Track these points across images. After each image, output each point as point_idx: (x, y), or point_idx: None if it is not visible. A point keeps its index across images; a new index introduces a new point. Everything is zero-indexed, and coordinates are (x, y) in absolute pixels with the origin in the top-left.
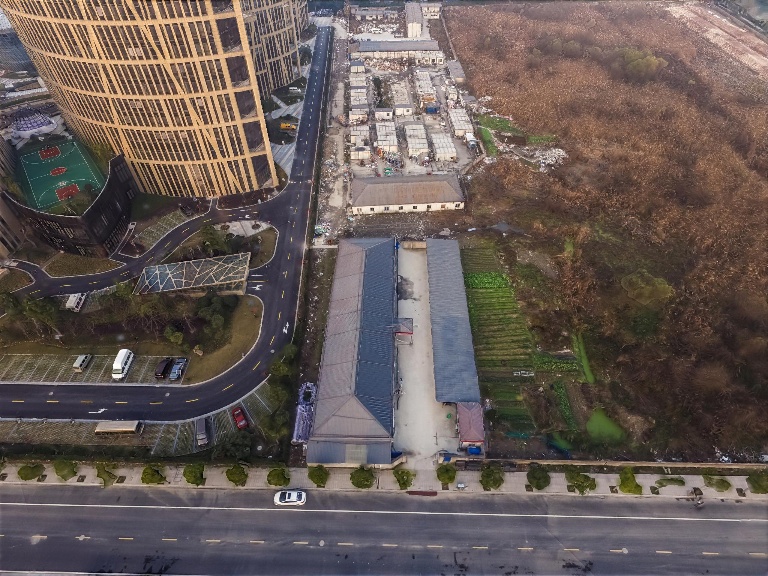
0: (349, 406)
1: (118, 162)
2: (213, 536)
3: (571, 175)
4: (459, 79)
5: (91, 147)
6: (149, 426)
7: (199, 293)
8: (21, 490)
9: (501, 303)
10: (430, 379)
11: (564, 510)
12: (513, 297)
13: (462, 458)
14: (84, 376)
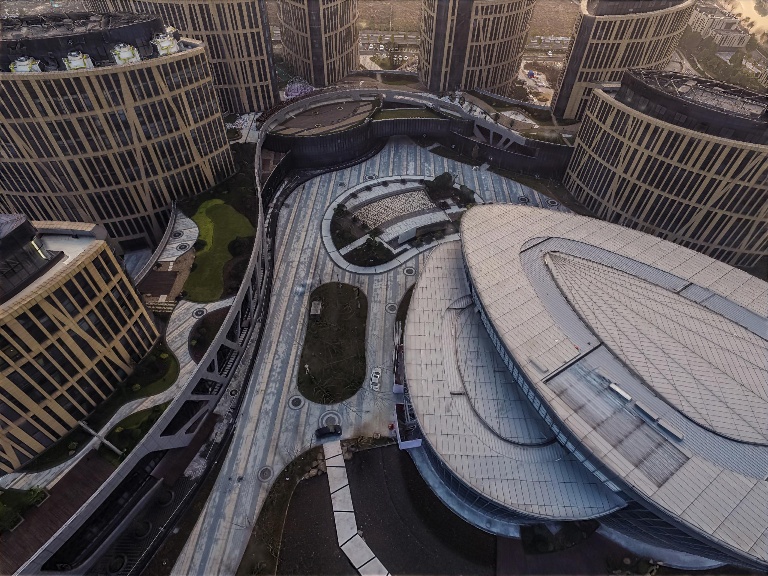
0: None
1: None
2: None
3: None
4: None
5: None
6: None
7: None
8: None
9: None
10: None
11: None
12: None
13: None
14: None
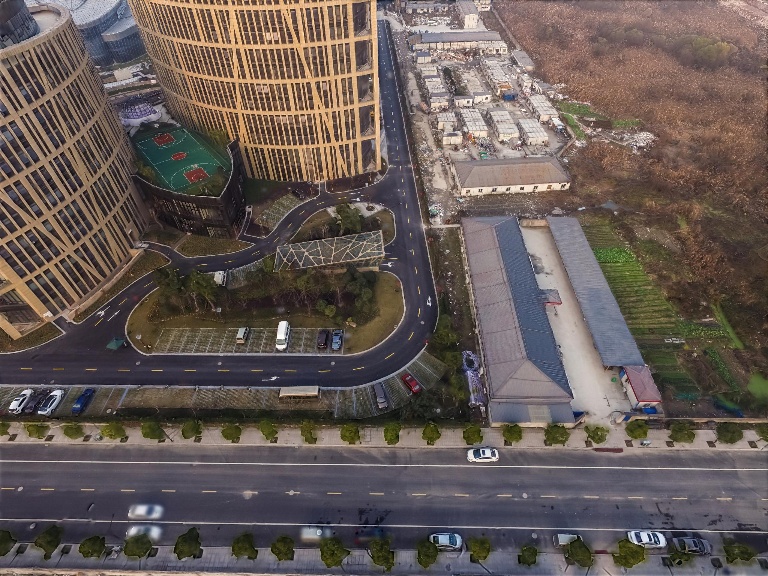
0: (524, 369)
1: (233, 147)
2: (418, 490)
3: (665, 157)
4: (529, 67)
5: (203, 133)
6: (324, 392)
7: (337, 270)
8: (219, 451)
9: (633, 276)
10: (585, 346)
11: (751, 464)
12: (642, 270)
13: (642, 417)
14: (246, 347)
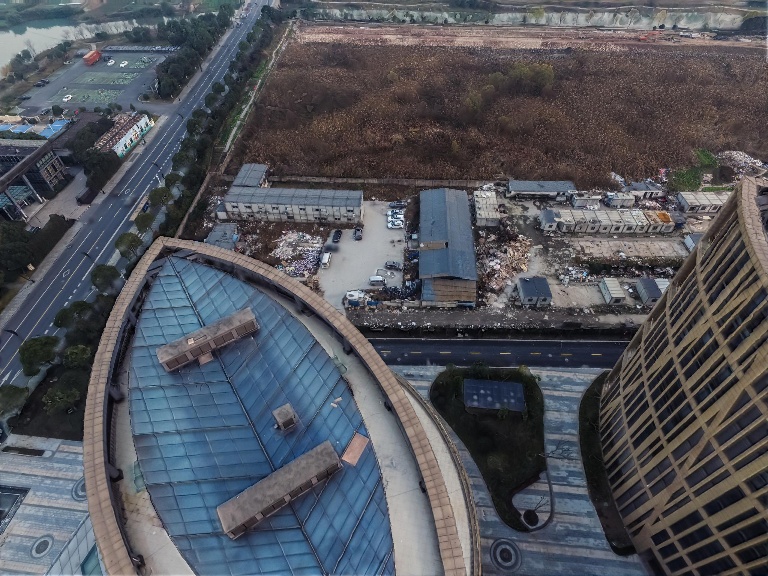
0: None
1: None
2: None
3: None
4: None
5: None
6: None
7: None
8: None
9: None
10: None
11: None
12: None
13: None
14: None
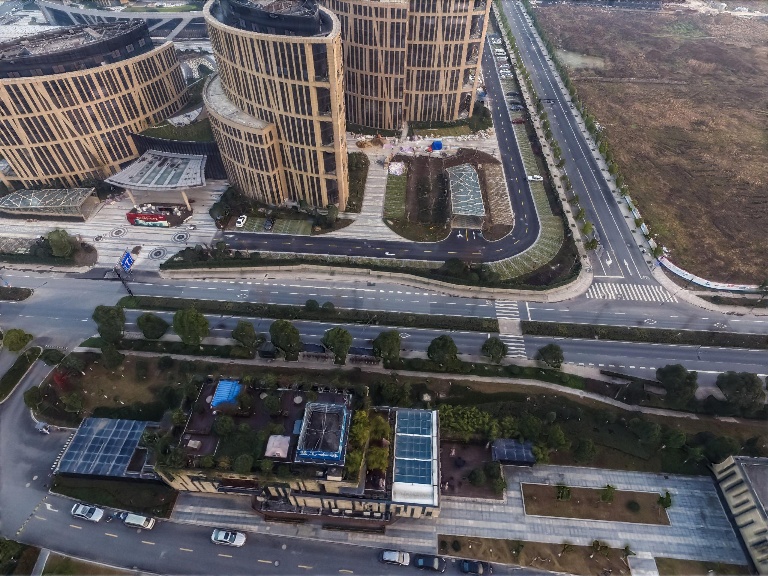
0: None
1: None
2: (507, 6)
3: None
4: None
5: None
6: None
7: None
8: None
9: None
10: None
11: None
12: None
13: None
14: None
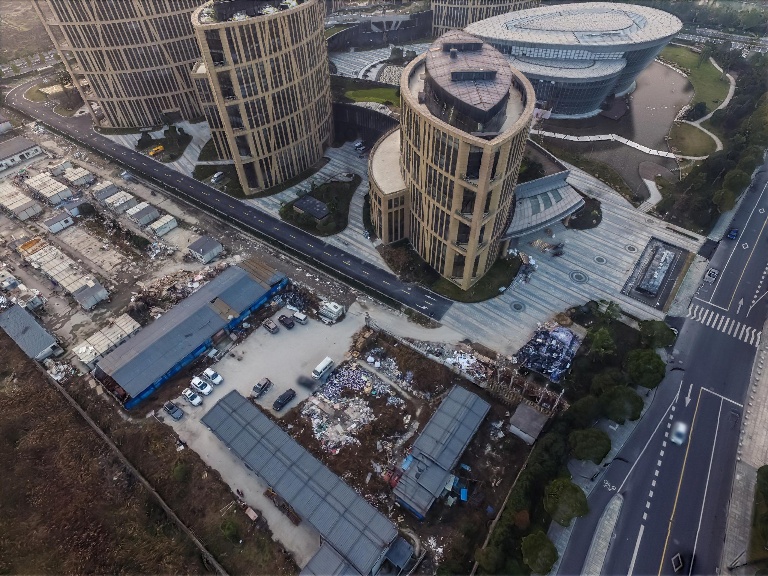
0: None
1: None
2: None
3: None
4: None
5: None
6: None
7: None
8: None
9: None
10: None
11: None
12: None
13: None
14: None
